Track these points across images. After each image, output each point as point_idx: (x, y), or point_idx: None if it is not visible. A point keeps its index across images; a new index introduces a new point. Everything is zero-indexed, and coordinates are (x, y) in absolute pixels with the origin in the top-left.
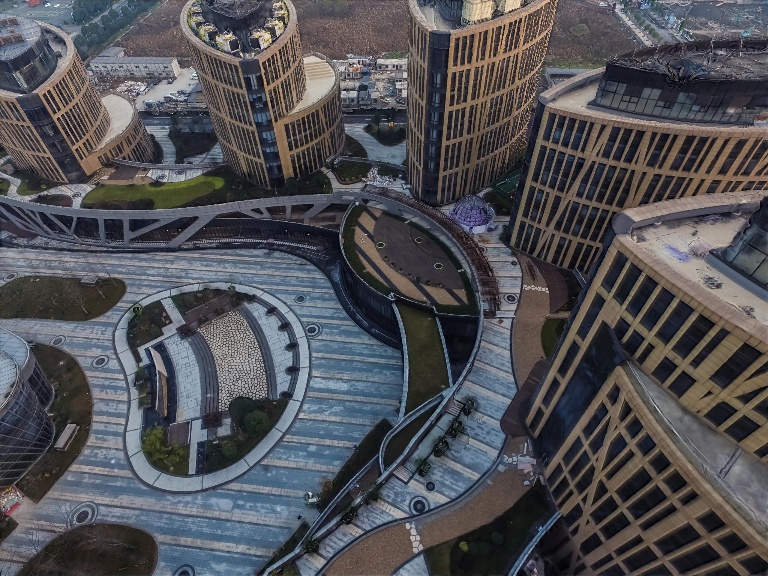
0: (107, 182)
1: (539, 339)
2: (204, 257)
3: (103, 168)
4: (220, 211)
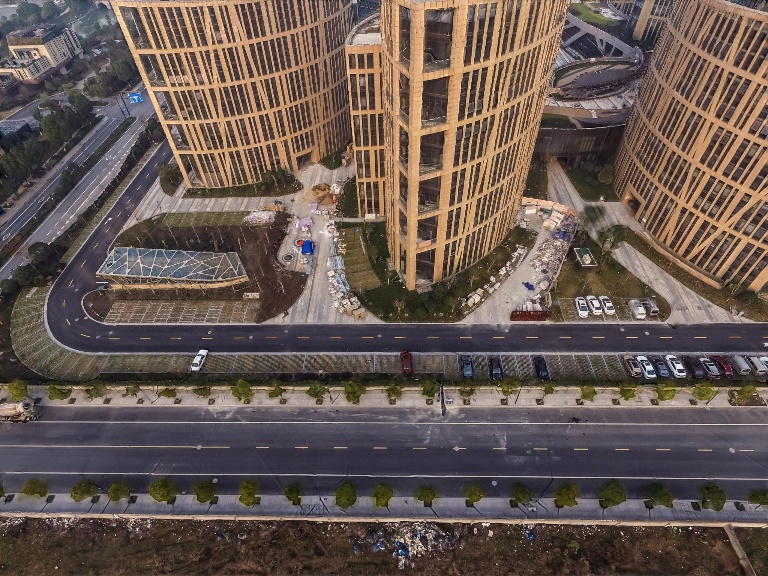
0: (587, 4)
1: (546, 112)
2: (563, 55)
3: (599, 0)
4: (589, 31)
